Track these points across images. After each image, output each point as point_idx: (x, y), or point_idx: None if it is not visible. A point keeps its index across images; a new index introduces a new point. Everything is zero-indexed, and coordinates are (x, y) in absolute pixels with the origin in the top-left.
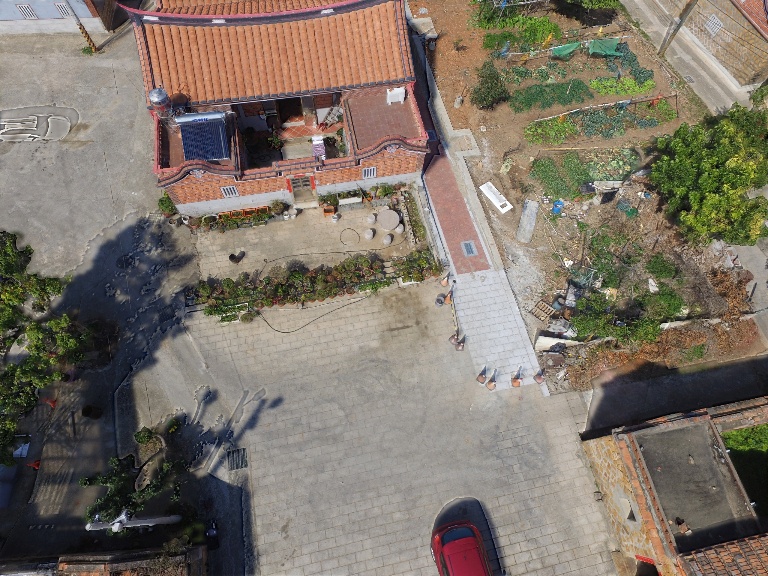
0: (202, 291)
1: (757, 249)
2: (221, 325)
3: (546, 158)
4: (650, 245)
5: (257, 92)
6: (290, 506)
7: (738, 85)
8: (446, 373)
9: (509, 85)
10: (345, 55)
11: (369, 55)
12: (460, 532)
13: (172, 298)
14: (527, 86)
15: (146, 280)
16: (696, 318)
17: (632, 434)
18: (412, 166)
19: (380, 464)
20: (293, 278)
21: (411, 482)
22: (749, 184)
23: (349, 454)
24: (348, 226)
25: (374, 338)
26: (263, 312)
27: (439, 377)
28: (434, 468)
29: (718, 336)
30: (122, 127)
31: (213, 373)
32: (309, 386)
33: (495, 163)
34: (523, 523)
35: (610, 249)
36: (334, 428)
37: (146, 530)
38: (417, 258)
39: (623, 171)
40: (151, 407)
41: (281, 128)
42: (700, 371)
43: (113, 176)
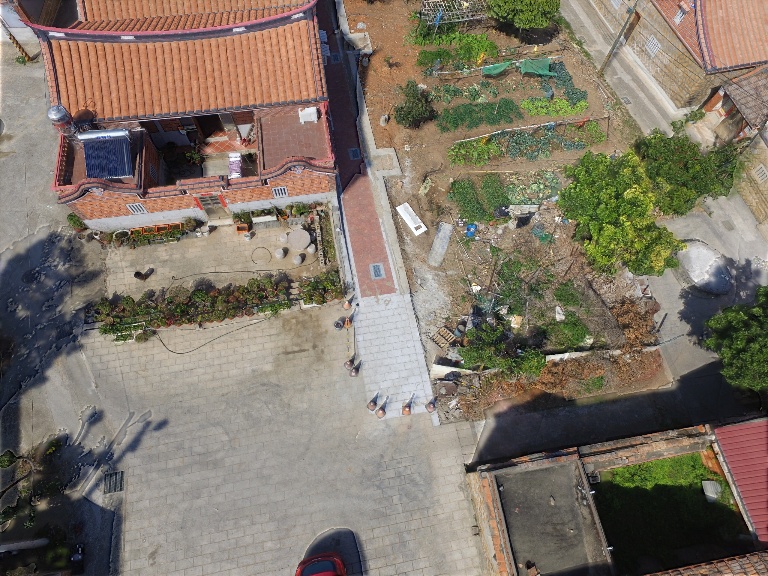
0: (101, 309)
1: (672, 278)
2: (116, 344)
3: (466, 180)
4: (562, 272)
5: (165, 110)
6: (161, 532)
7: (675, 107)
8: (337, 399)
9: (438, 104)
10: (257, 74)
11: (281, 74)
12: (321, 566)
13: (72, 315)
14: (457, 105)
15: (49, 296)
16: (596, 349)
17: (491, 473)
18: (324, 186)
19: (258, 491)
20: (195, 297)
21: (287, 511)
22: (656, 214)
23: (227, 480)
24: (261, 244)
25: (268, 361)
26: (160, 332)
27: (329, 403)
28: (312, 497)
29: (619, 368)
30: (46, 138)
31: (101, 393)
32: (196, 409)
33: (415, 183)
34: (395, 556)
35: (521, 275)
36: (216, 453)
37: (9, 554)
38: (323, 280)
39: (543, 195)
40: (34, 426)
41: (204, 143)
42: (598, 403)
43: (30, 188)
